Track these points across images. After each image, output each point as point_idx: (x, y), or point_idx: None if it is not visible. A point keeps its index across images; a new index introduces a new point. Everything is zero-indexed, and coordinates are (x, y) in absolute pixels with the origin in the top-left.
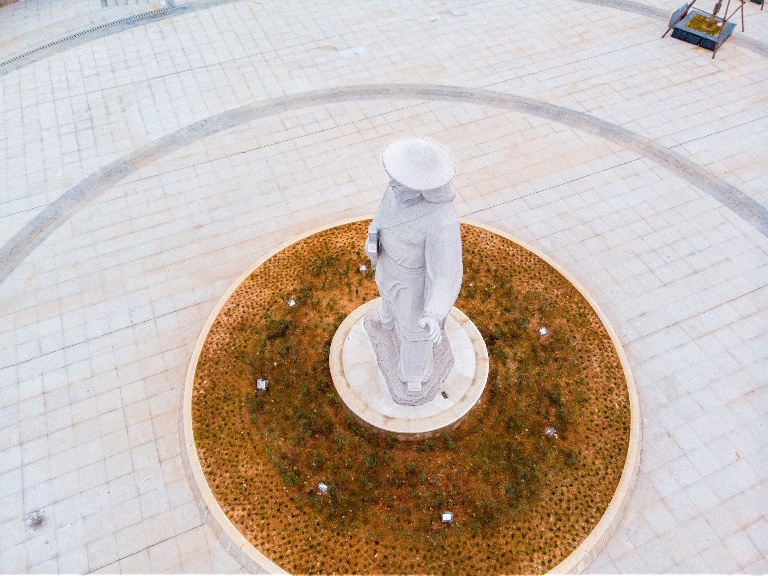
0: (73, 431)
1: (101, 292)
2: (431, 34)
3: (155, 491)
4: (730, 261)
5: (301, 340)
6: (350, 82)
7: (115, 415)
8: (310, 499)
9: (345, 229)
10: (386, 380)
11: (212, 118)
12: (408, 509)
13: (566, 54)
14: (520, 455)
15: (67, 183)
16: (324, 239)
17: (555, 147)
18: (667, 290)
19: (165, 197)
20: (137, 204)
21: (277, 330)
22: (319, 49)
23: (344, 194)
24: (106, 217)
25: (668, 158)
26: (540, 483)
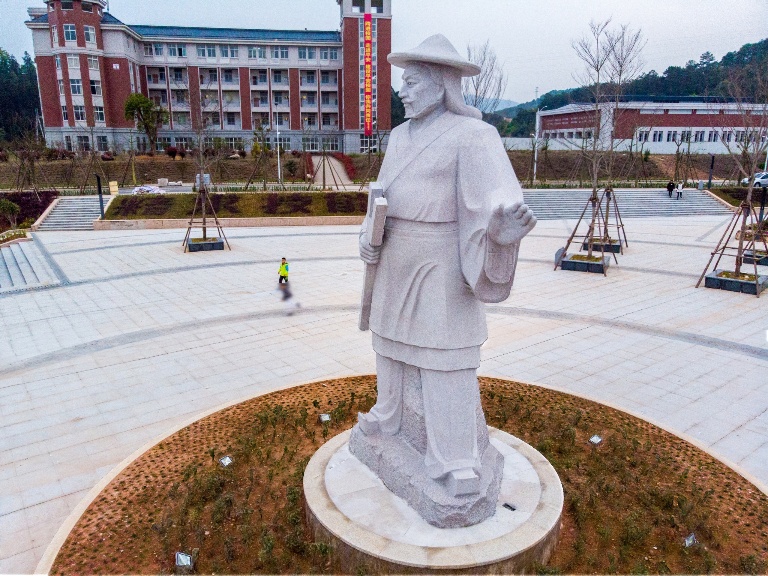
0: None
1: None
2: (344, 280)
3: None
4: (743, 377)
5: (248, 498)
6: (269, 308)
7: None
8: None
9: (291, 392)
10: (409, 499)
11: (105, 339)
12: None
13: None
14: (673, 574)
15: None
16: (264, 402)
17: (503, 327)
18: (702, 404)
19: (30, 400)
20: None
21: (208, 484)
22: (231, 294)
23: (281, 375)
24: None
25: (617, 324)
26: None
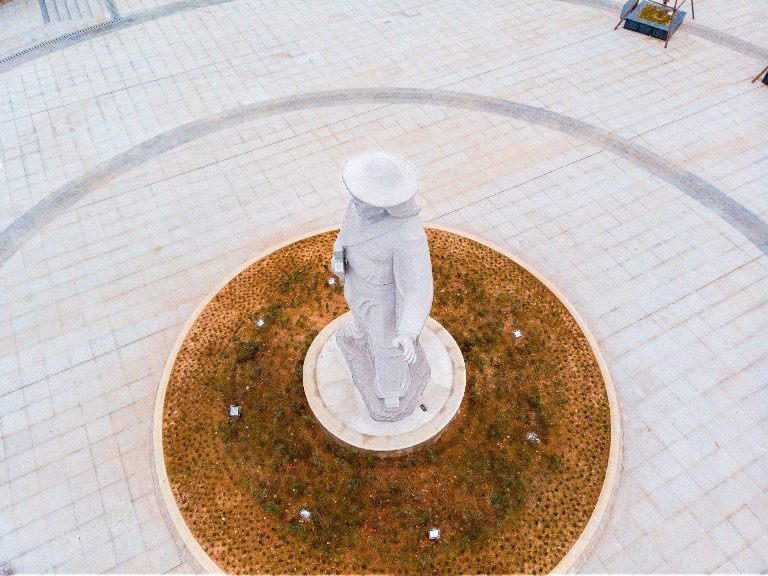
0: (37, 476)
1: (59, 325)
2: (385, 36)
3: (129, 532)
4: (695, 249)
5: (273, 361)
6: (306, 89)
7: (81, 455)
8: (292, 528)
9: (311, 242)
10: (363, 397)
11: (165, 134)
12: (394, 529)
13: (521, 50)
14: (503, 463)
15: (15, 211)
16: (290, 254)
17: (517, 145)
18: (637, 283)
19: (121, 220)
20: (92, 229)
21: (247, 353)
22: (272, 57)
23: (307, 205)
24: (59, 245)
25: (628, 149)
26: (525, 490)
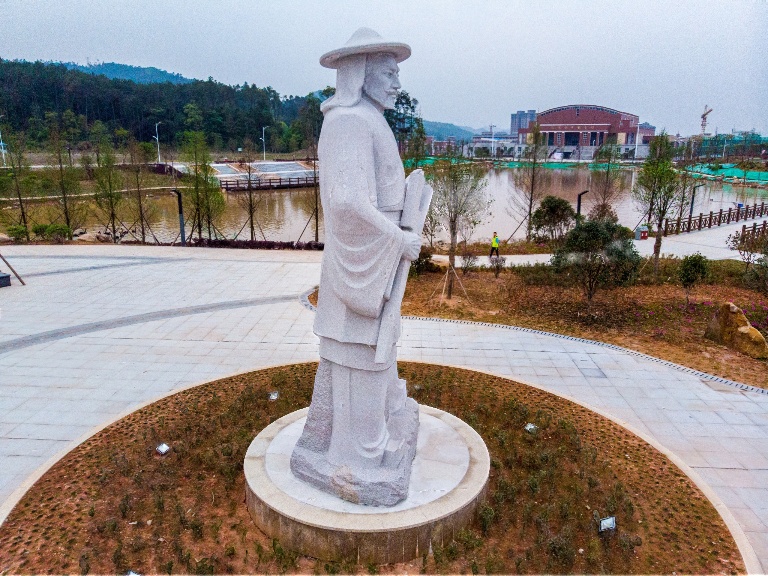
0: None
1: None
2: None
3: (764, 507)
4: None
5: (527, 568)
6: None
7: None
8: None
9: None
10: None
11: None
12: None
13: None
14: None
15: None
16: None
17: None
18: None
19: None
20: None
21: (575, 575)
22: None
23: None
24: None
25: None
26: None
